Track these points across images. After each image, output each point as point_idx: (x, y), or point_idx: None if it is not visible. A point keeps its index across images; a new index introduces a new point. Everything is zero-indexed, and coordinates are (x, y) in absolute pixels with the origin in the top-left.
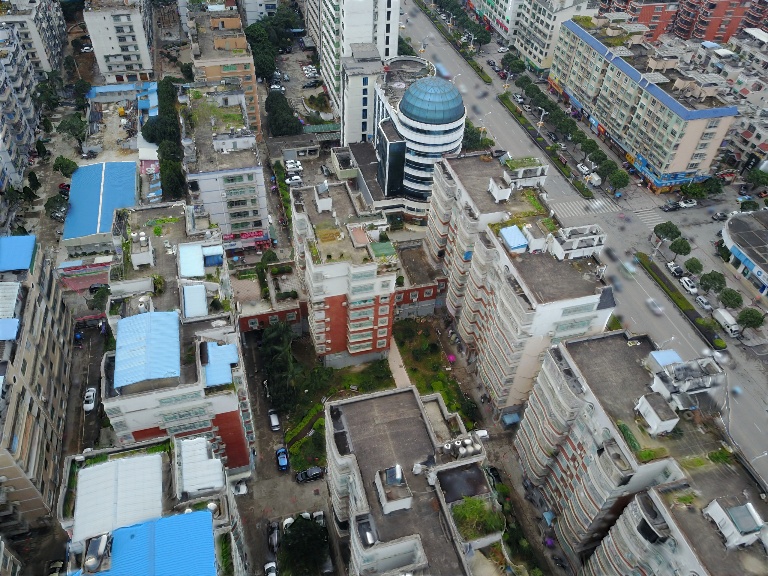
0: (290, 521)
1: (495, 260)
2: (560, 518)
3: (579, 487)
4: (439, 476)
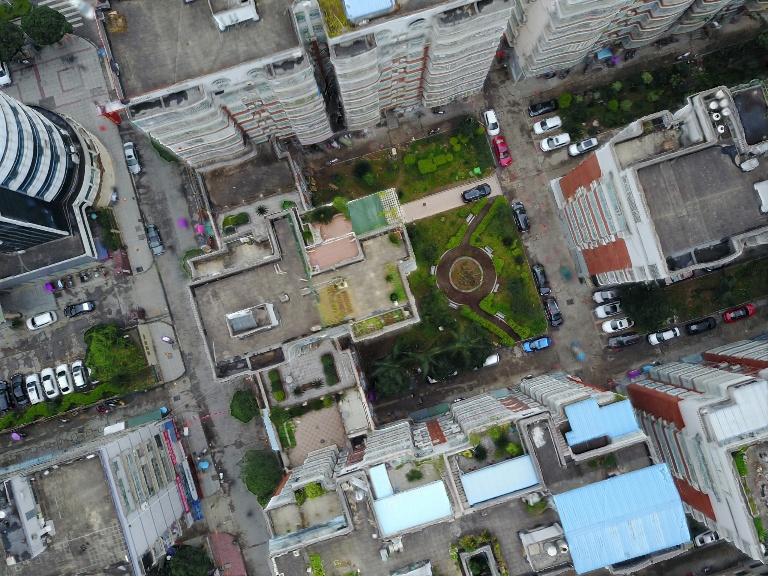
0: (607, 326)
1: (384, 40)
2: (638, 37)
3: (667, 1)
4: (748, 142)
